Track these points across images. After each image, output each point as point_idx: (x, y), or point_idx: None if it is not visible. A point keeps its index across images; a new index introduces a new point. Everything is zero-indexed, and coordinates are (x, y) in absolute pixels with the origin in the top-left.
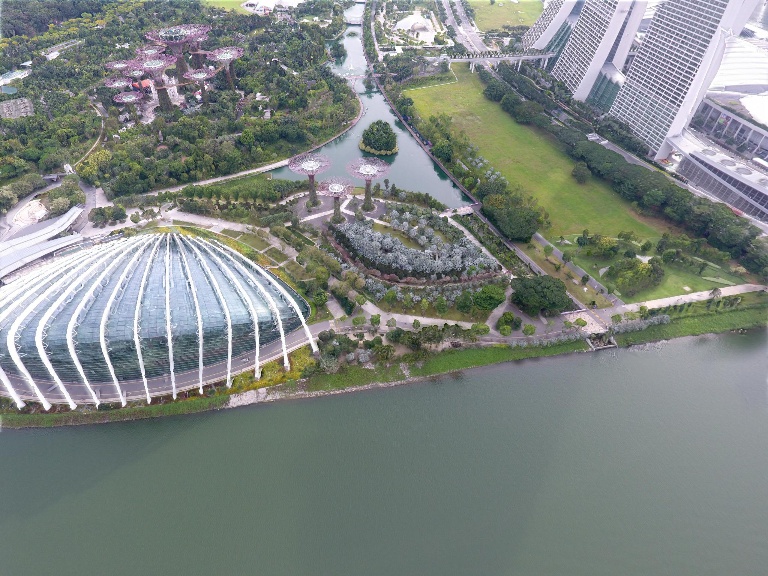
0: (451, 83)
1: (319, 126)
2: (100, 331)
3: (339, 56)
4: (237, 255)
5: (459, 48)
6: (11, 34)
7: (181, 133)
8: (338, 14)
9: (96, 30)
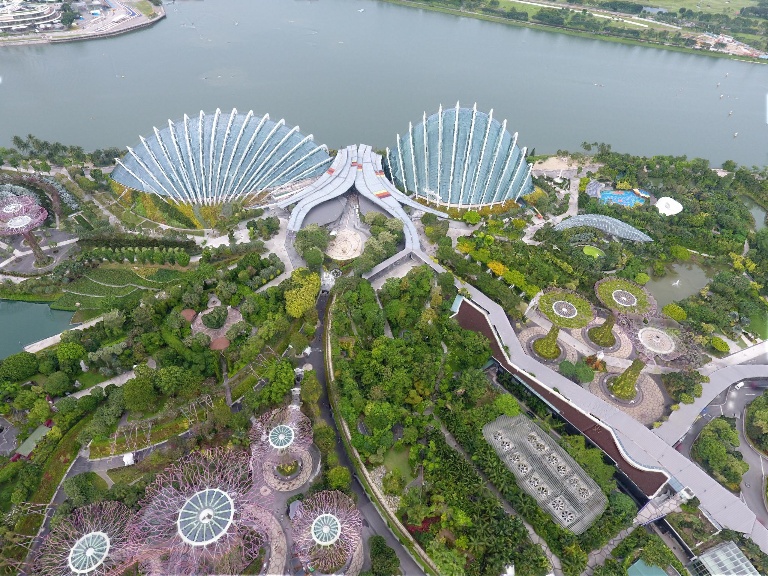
0: None
1: None
2: None
3: None
4: None
5: None
6: None
7: None
8: None
9: None
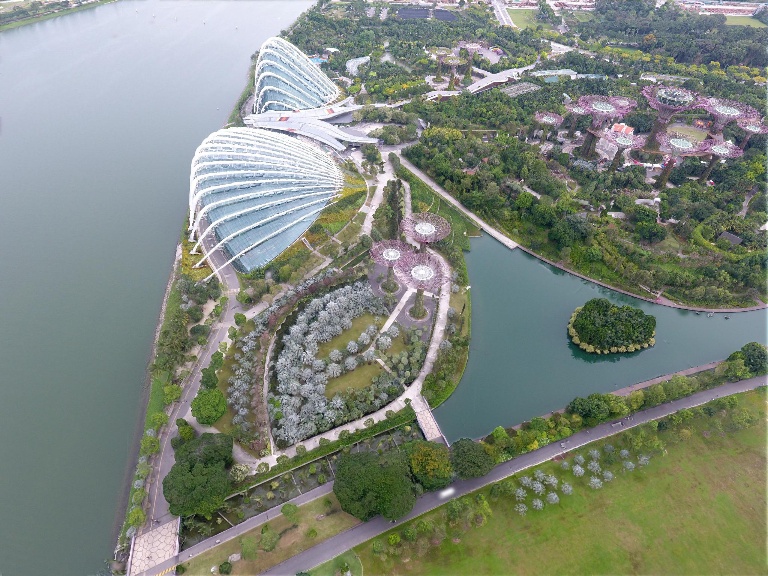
0: None
1: (602, 258)
2: (197, 155)
3: None
4: None
5: None
6: (676, 56)
7: None
8: None
9: (726, 80)
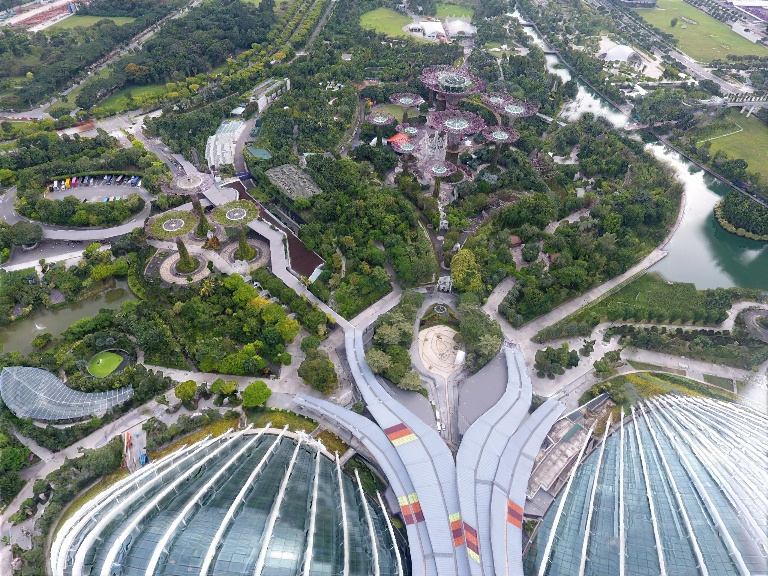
0: (738, 132)
1: None
2: None
3: (572, 95)
4: None
5: (712, 86)
6: (190, 71)
7: None
8: (527, 41)
9: (290, 66)
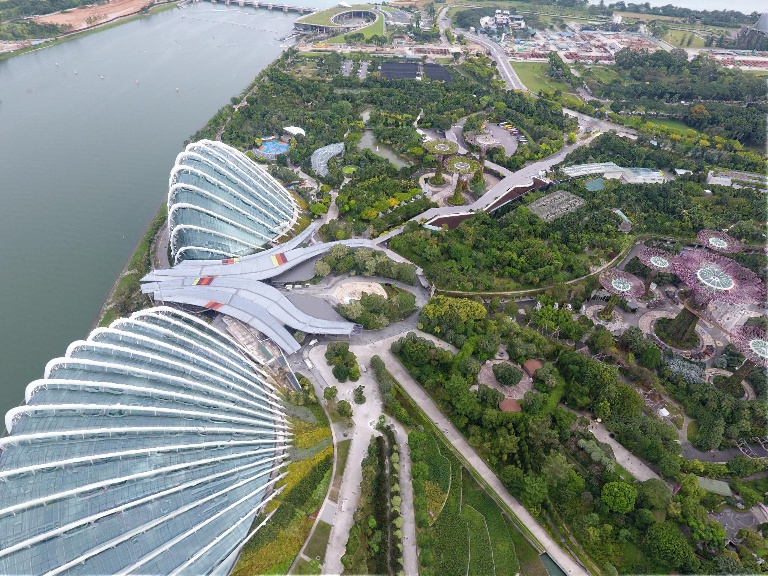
0: None
1: None
2: None
3: None
4: (210, 575)
5: None
6: None
7: (580, 378)
8: None
9: None
